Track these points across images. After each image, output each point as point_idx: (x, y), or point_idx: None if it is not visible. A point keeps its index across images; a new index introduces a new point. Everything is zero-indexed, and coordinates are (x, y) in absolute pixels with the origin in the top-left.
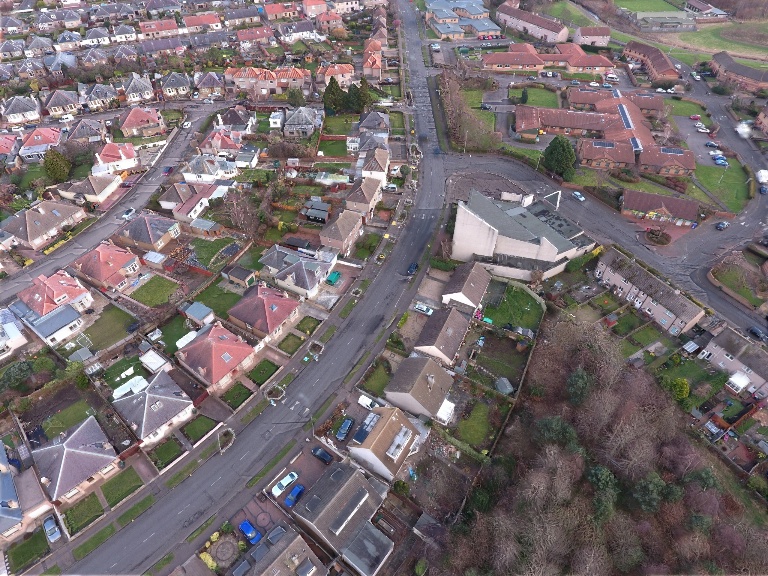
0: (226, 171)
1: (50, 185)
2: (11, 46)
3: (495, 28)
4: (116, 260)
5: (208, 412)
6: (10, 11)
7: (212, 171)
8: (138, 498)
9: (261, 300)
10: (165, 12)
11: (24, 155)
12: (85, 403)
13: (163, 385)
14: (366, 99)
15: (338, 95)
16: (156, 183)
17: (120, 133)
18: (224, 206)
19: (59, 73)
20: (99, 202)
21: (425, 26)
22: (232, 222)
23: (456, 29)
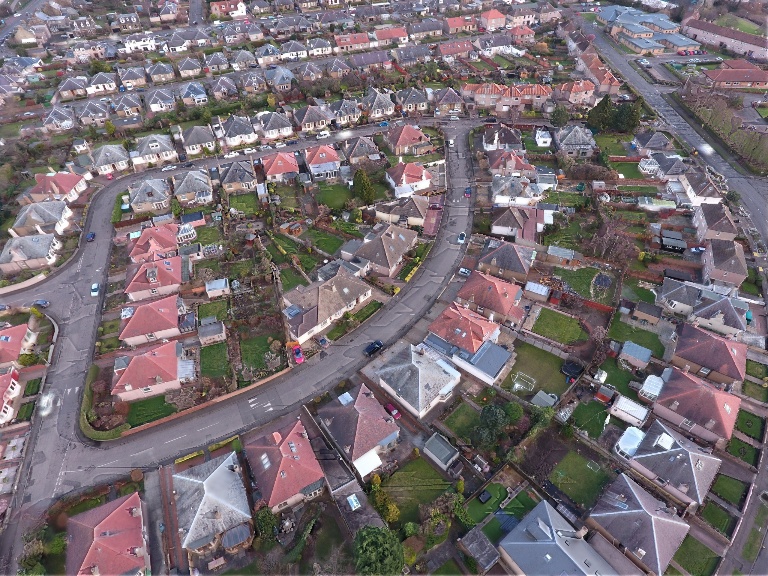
0: (536, 194)
1: (361, 206)
2: (219, 59)
3: (696, 43)
4: (508, 292)
5: (725, 470)
6: (185, 23)
7: (529, 194)
8: (726, 573)
9: (721, 343)
10: (342, 25)
11: (315, 173)
12: (579, 455)
13: (682, 440)
14: (638, 118)
15: (609, 114)
16: (464, 205)
17: (388, 151)
18: (558, 232)
19: (283, 87)
20: (420, 225)
21: (615, 41)
22: (594, 251)
23: (657, 44)
